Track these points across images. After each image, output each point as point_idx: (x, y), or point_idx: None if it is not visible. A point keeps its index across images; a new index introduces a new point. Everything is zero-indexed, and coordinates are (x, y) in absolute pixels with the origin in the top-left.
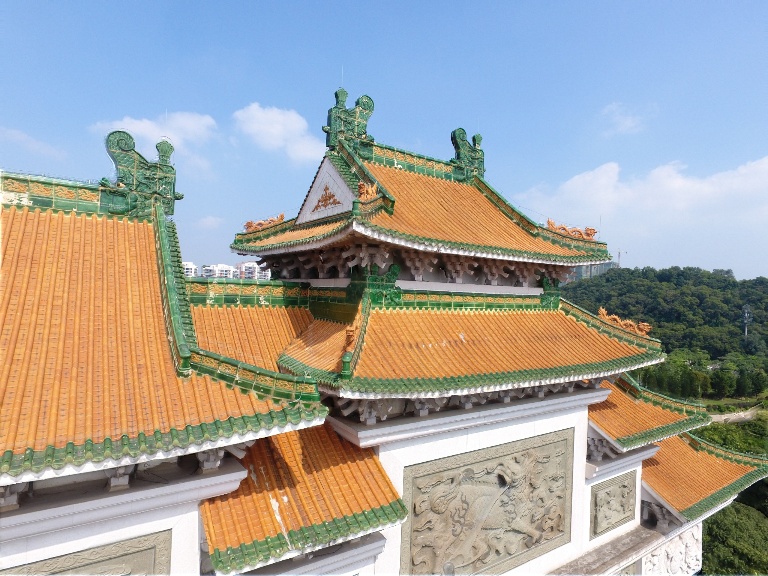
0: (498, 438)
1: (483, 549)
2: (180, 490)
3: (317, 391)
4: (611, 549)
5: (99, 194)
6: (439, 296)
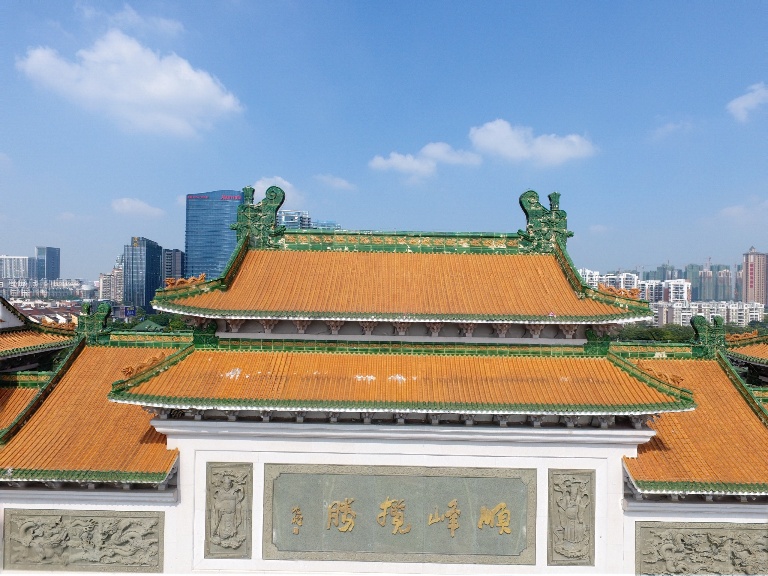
0: None
1: None
2: None
3: None
4: None
5: (691, 348)
6: None
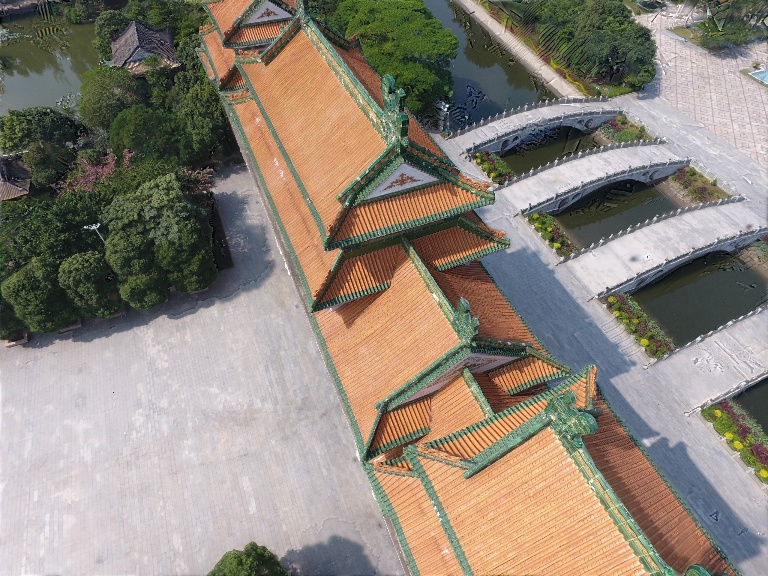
0: None
1: None
2: None
3: (364, 457)
4: None
5: (453, 317)
6: None
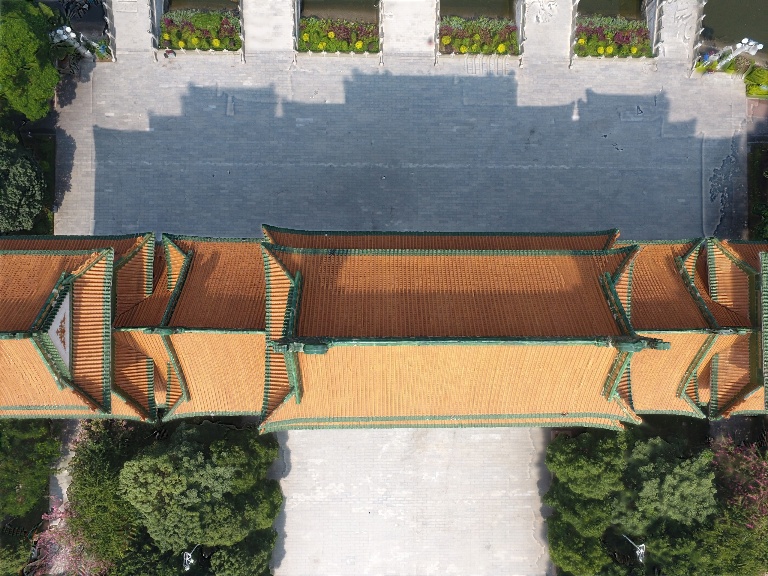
0: None
1: None
2: None
3: None
4: None
5: None
6: None
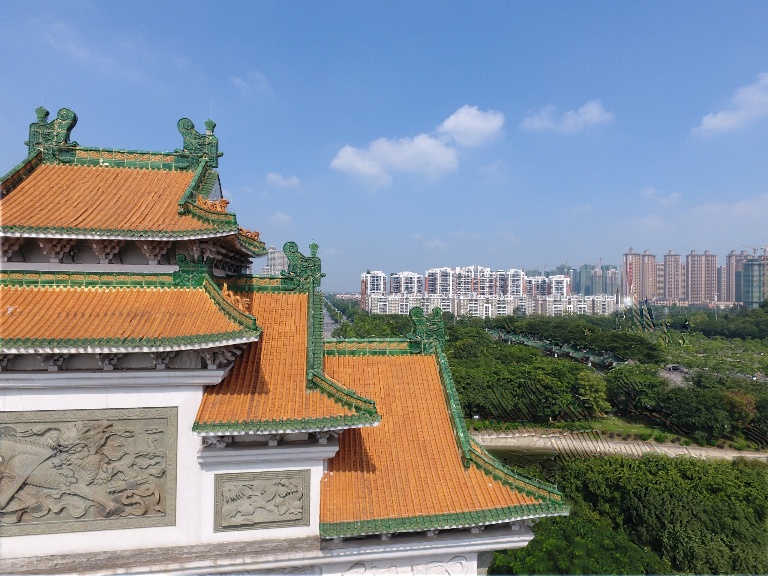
0: (50, 404)
1: (30, 503)
2: None
3: None
4: (237, 547)
5: None
6: (23, 275)
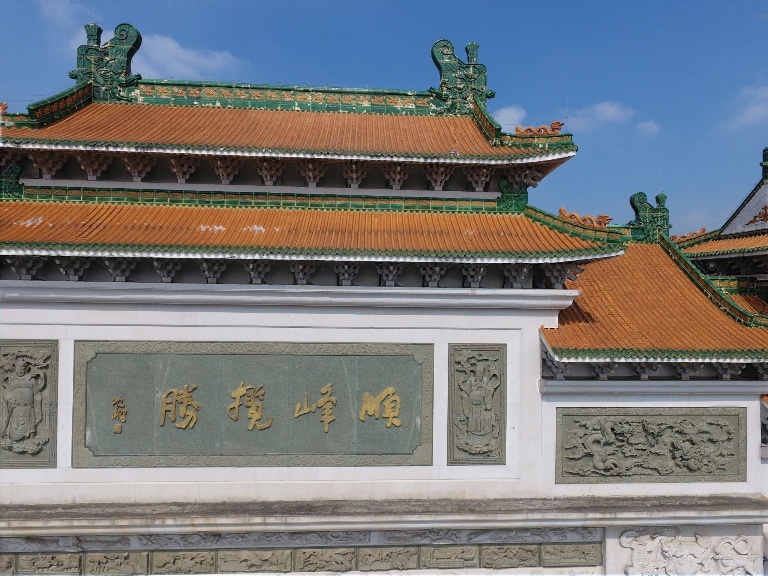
0: None
1: None
2: (759, 385)
3: None
4: None
5: (630, 230)
6: None
